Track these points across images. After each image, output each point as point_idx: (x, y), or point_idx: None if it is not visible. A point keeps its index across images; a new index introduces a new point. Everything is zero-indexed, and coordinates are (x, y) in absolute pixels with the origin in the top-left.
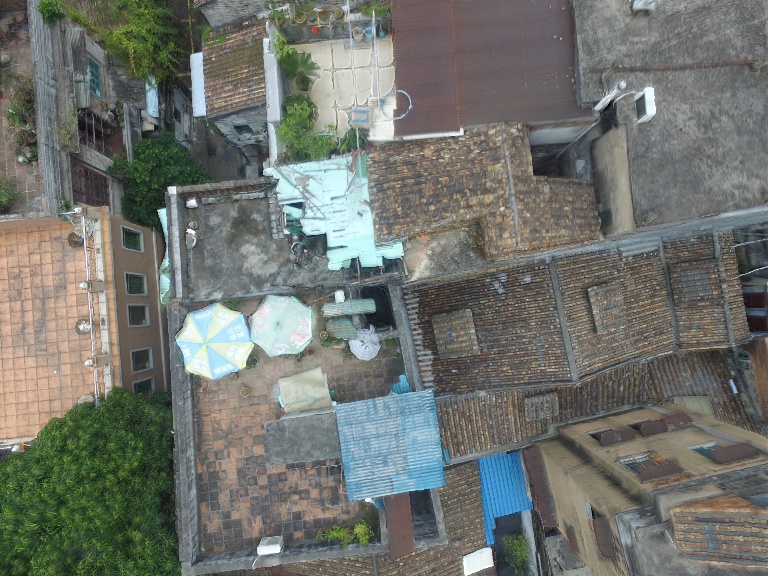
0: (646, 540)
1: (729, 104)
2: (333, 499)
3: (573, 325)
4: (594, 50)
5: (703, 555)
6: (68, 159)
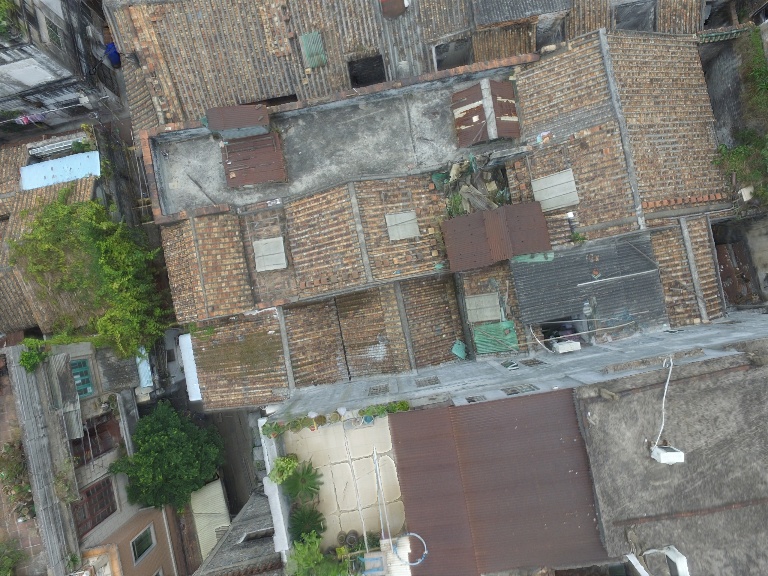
0: None
1: (765, 544)
2: None
3: None
4: (615, 499)
5: None
6: (69, 508)
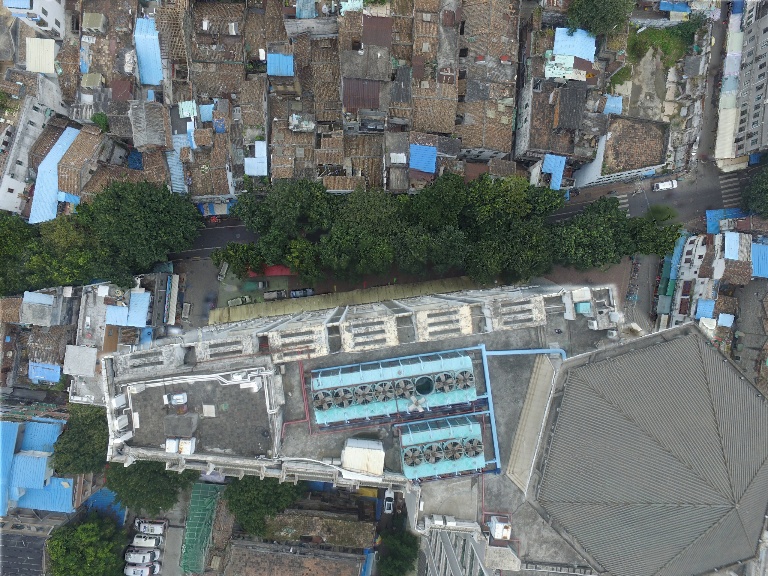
0: None
1: (360, 70)
2: (293, 1)
3: None
4: (373, 48)
5: (285, 47)
6: None
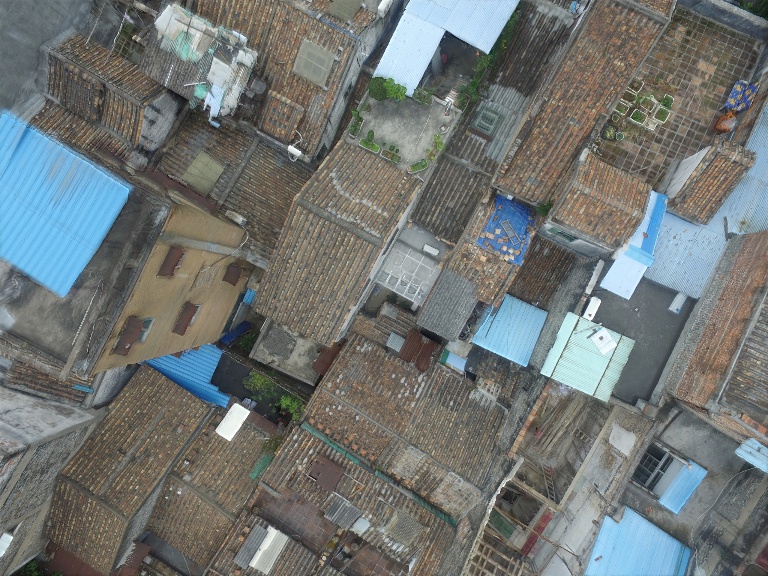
0: (16, 317)
1: None
2: None
3: None
4: None
5: None
6: None
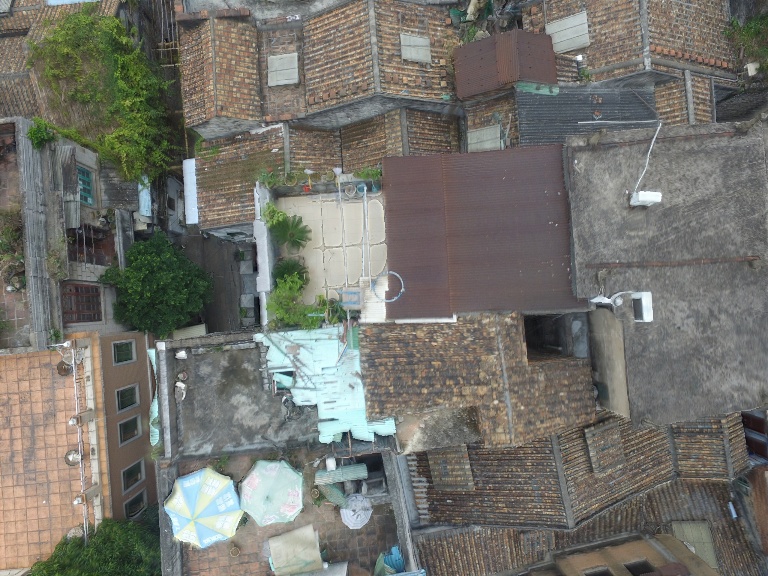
0: None
1: (728, 301)
2: None
3: (569, 468)
4: (590, 244)
5: None
6: (57, 286)
